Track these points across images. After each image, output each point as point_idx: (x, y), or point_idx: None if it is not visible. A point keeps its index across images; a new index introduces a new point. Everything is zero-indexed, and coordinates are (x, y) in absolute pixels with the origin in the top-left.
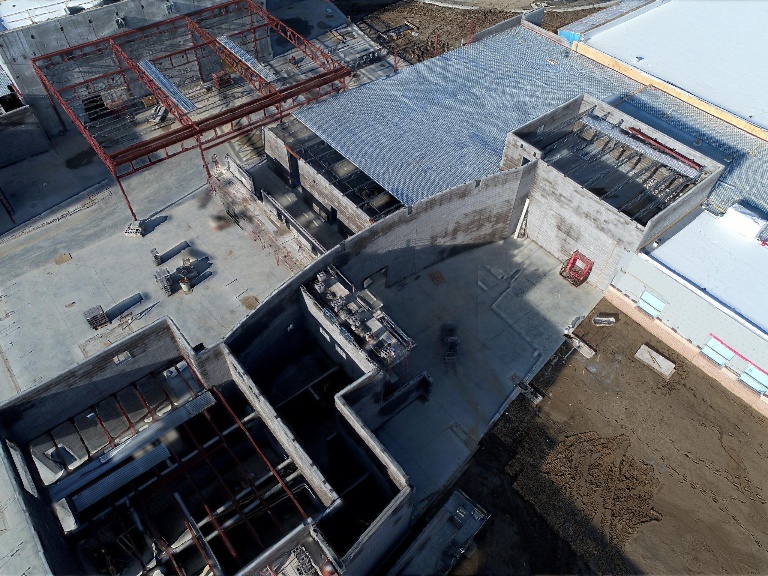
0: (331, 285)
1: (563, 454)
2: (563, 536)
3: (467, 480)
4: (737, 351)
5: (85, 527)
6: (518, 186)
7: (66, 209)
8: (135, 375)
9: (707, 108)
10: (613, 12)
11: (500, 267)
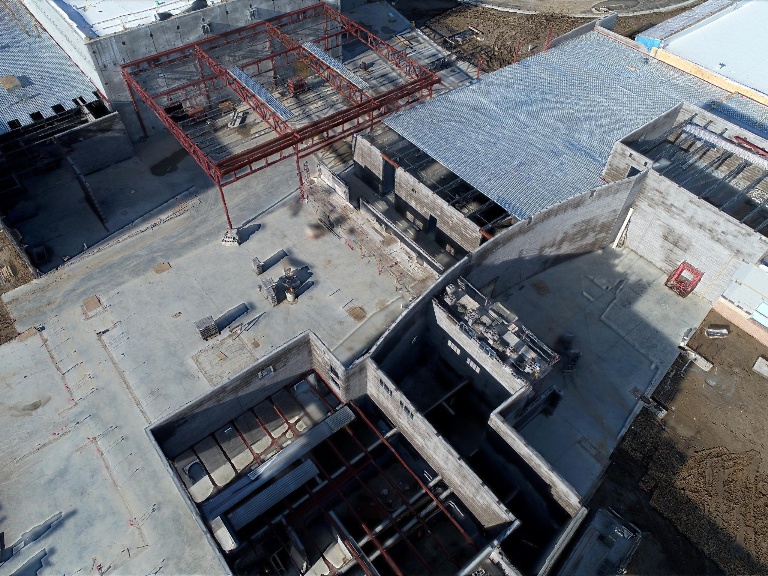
0: (460, 297)
1: (696, 470)
2: (709, 555)
3: (603, 496)
4: None
5: (244, 546)
6: (627, 196)
7: (158, 217)
8: (272, 389)
9: None
10: (689, 18)
11: (603, 277)
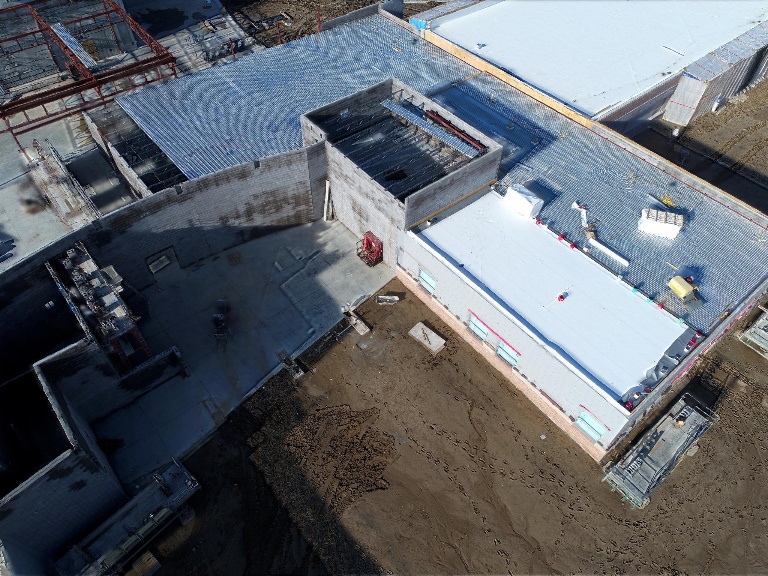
0: (82, 262)
1: (309, 426)
2: (284, 504)
3: (206, 451)
4: (488, 326)
5: None
6: (308, 167)
7: None
8: None
9: (531, 93)
10: (467, 0)
11: (301, 248)
